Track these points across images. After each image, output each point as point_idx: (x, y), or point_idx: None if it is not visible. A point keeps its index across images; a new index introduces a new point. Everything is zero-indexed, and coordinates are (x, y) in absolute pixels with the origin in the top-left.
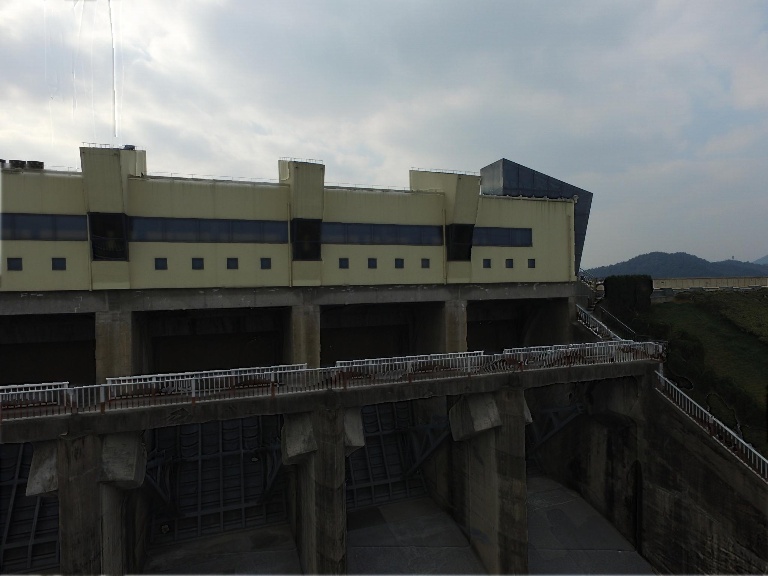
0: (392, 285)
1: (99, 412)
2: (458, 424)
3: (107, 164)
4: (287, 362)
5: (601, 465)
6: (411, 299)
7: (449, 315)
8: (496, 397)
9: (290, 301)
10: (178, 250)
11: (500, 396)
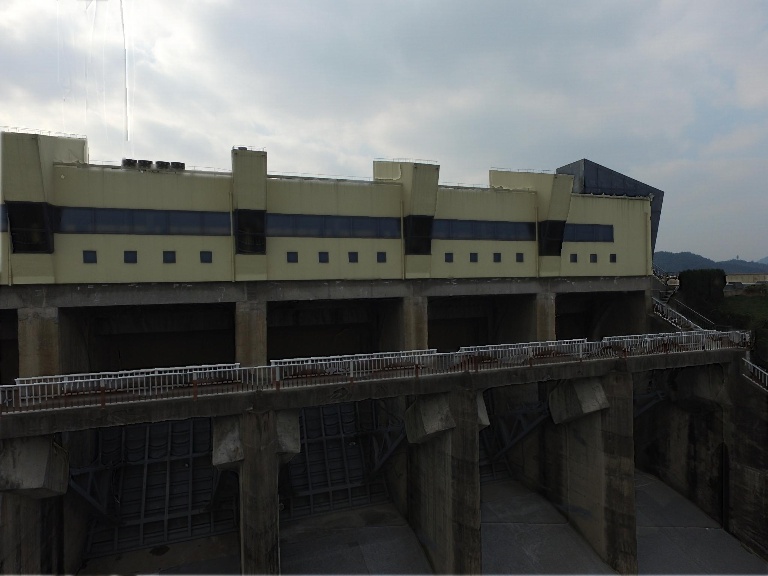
0: (490, 278)
1: (275, 390)
2: (561, 407)
3: (255, 165)
4: None
5: (682, 449)
6: (507, 291)
7: (540, 307)
8: (603, 381)
9: (402, 293)
10: (307, 244)
11: (607, 380)
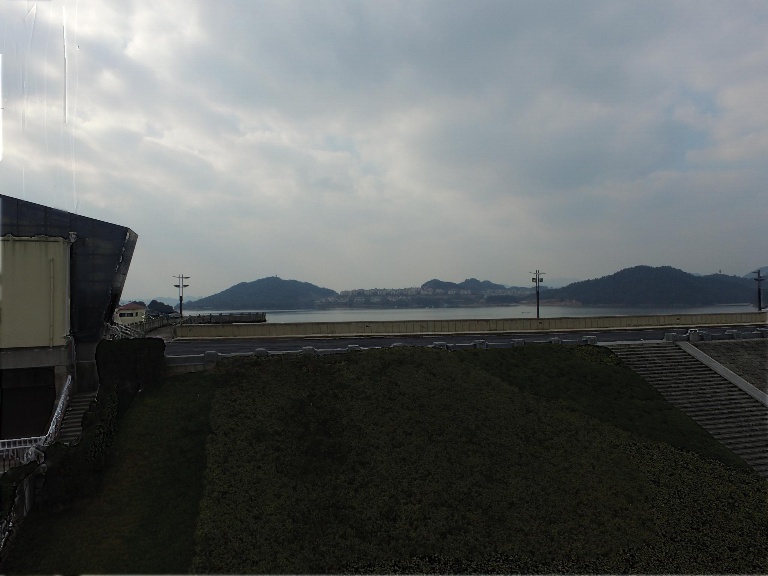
0: None
1: None
2: None
3: None
4: None
5: None
6: None
7: None
8: None
9: None
10: None
11: None
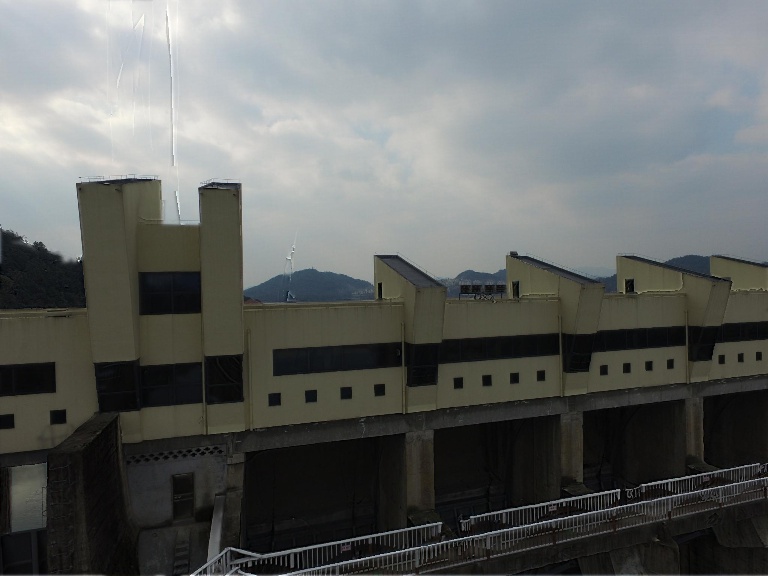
0: (753, 376)
1: (668, 519)
2: None
3: (595, 295)
4: (654, 442)
5: None
6: (765, 387)
7: None
8: None
9: (684, 395)
10: (614, 357)
11: None
